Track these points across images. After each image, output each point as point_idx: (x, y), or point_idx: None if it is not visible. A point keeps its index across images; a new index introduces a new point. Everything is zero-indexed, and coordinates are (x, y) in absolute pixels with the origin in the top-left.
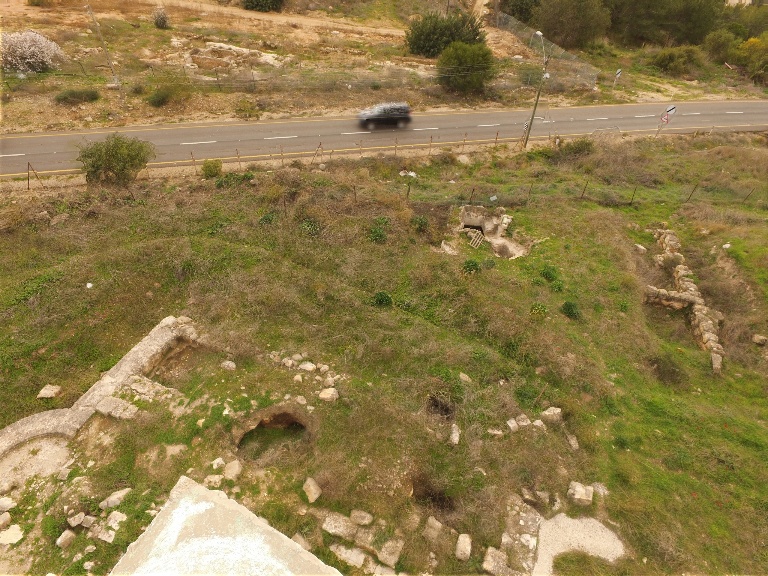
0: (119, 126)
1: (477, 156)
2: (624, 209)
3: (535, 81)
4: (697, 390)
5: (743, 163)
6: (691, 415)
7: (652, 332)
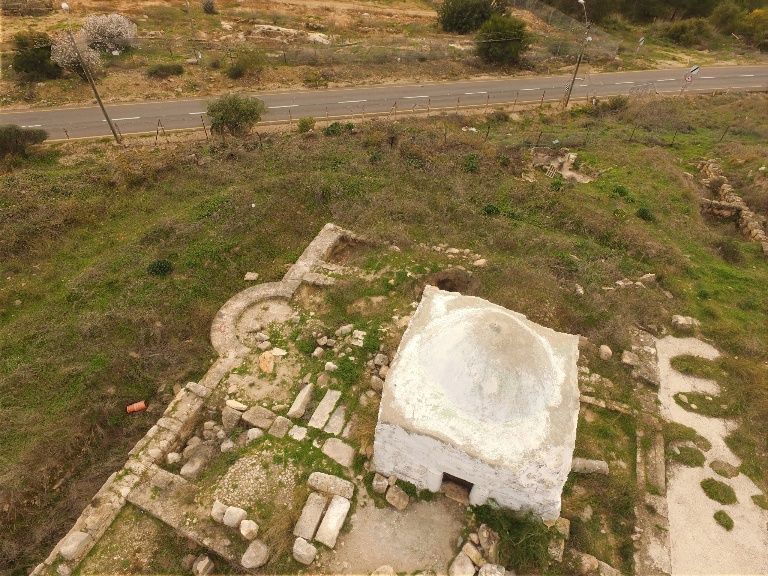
0: (208, 95)
1: (526, 114)
2: (667, 149)
3: (578, 44)
4: (753, 267)
5: (763, 112)
6: (754, 277)
7: (710, 231)
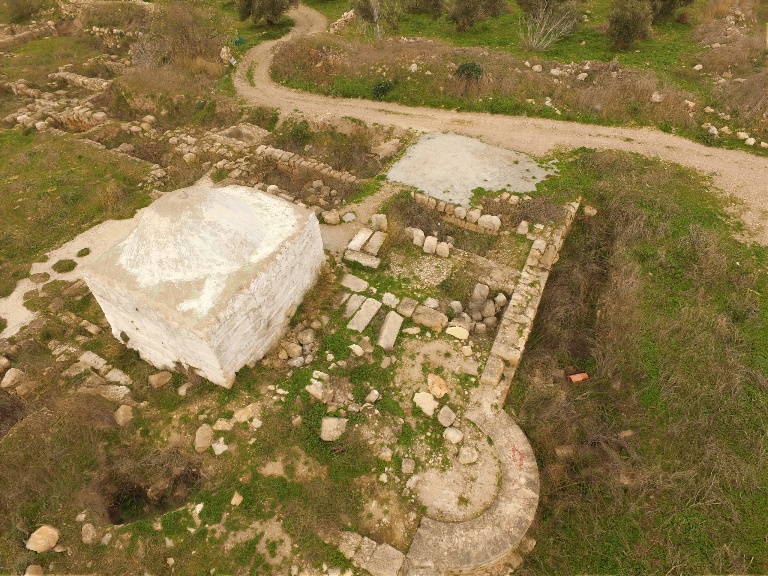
0: None
1: None
2: None
3: None
4: None
5: None
6: None
7: None
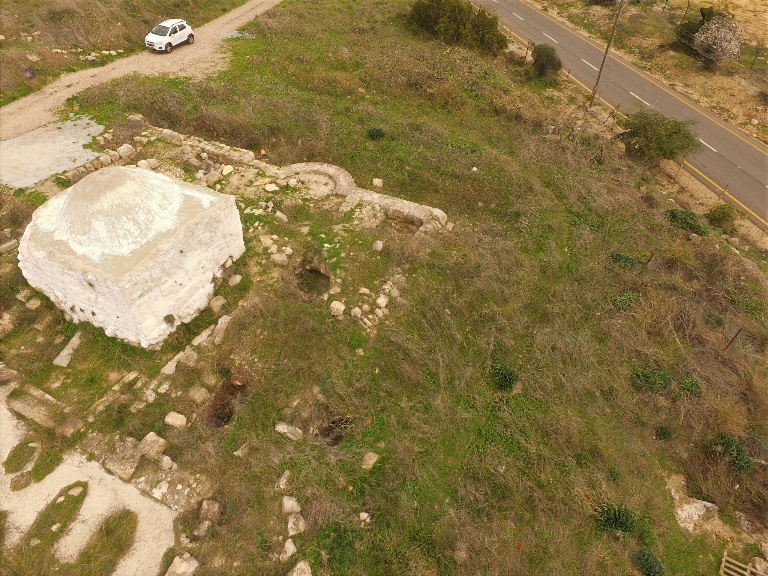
0: (762, 141)
1: None
2: None
3: None
4: None
5: None
6: None
7: None
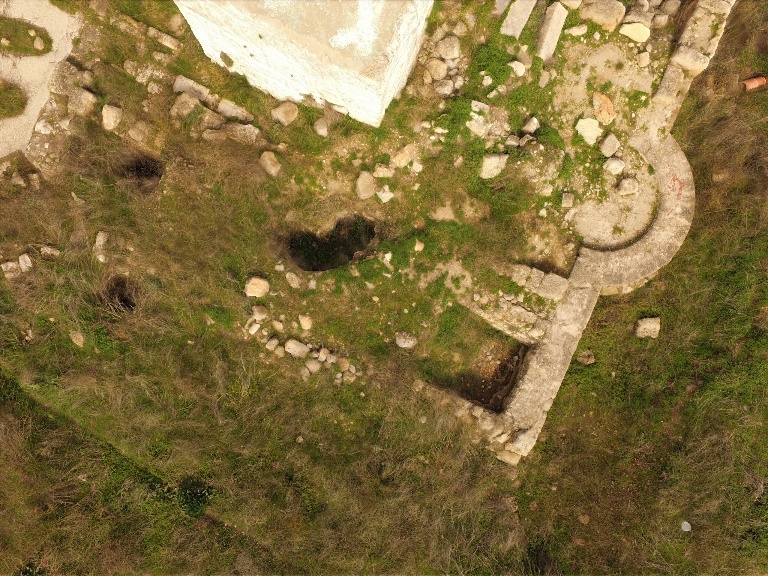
0: None
1: None
2: None
3: None
4: None
5: None
6: None
7: None
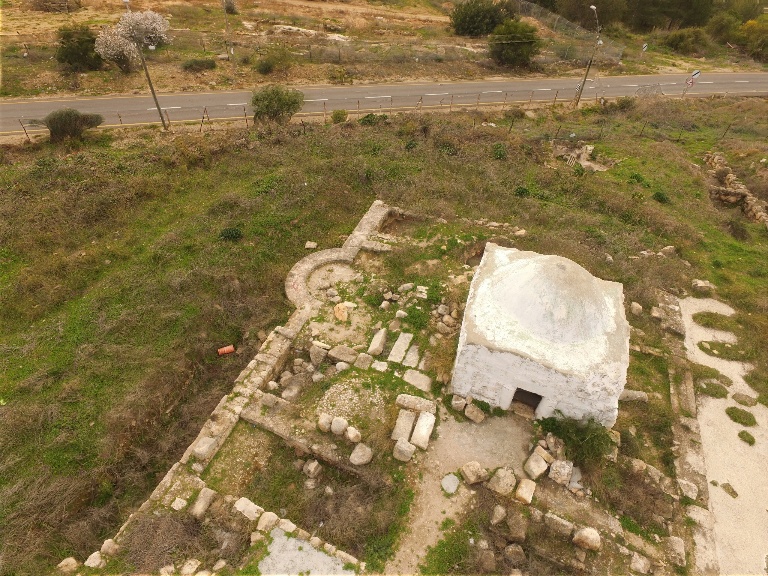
0: (241, 88)
1: (540, 112)
2: None
3: None
4: (758, 244)
5: (760, 113)
6: (761, 250)
7: None
